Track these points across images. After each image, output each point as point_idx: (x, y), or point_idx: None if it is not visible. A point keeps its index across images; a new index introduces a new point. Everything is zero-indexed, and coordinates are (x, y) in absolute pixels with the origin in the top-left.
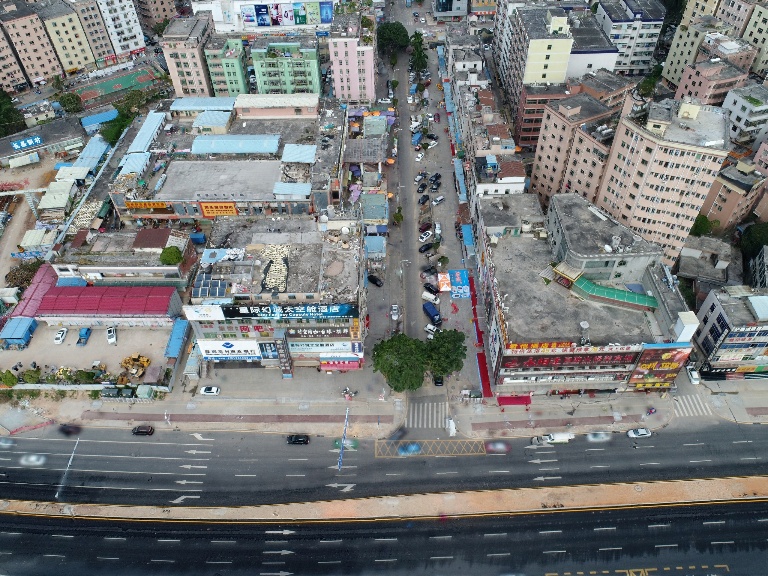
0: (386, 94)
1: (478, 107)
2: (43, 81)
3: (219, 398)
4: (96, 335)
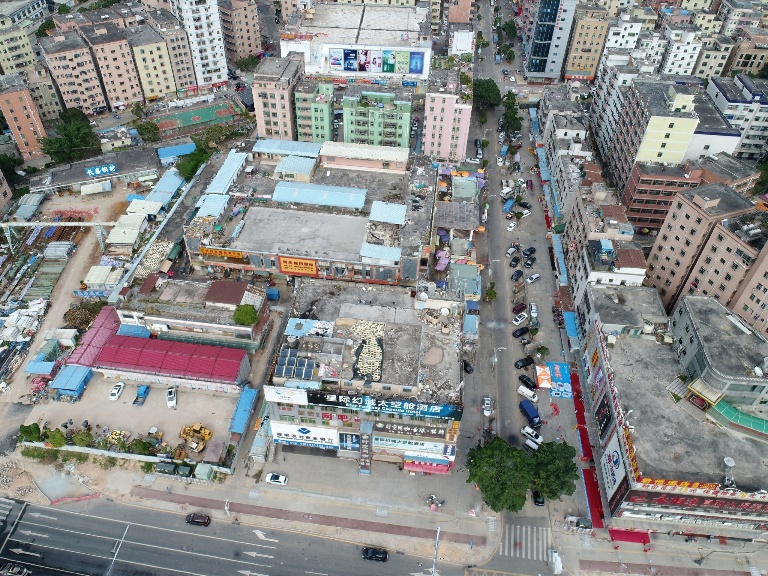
0: (474, 153)
1: (584, 181)
2: (122, 106)
3: (286, 489)
4: (155, 394)
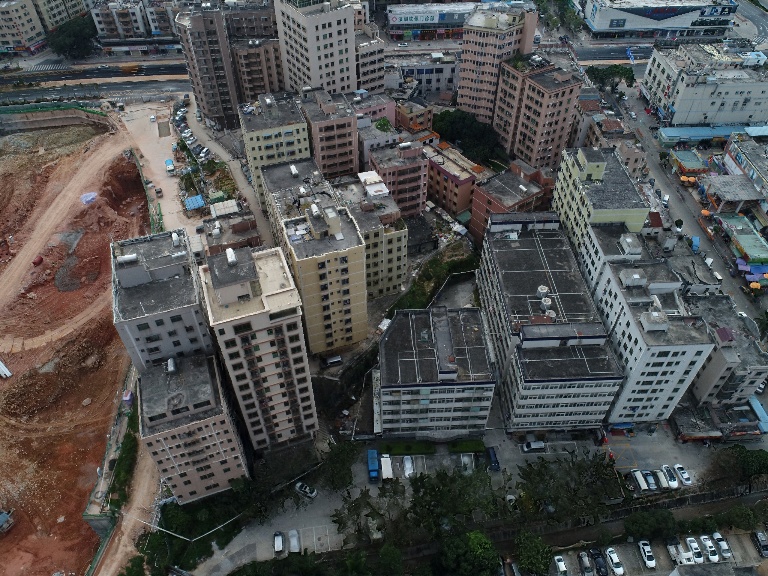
0: None
1: (640, 186)
2: None
3: None
4: None
